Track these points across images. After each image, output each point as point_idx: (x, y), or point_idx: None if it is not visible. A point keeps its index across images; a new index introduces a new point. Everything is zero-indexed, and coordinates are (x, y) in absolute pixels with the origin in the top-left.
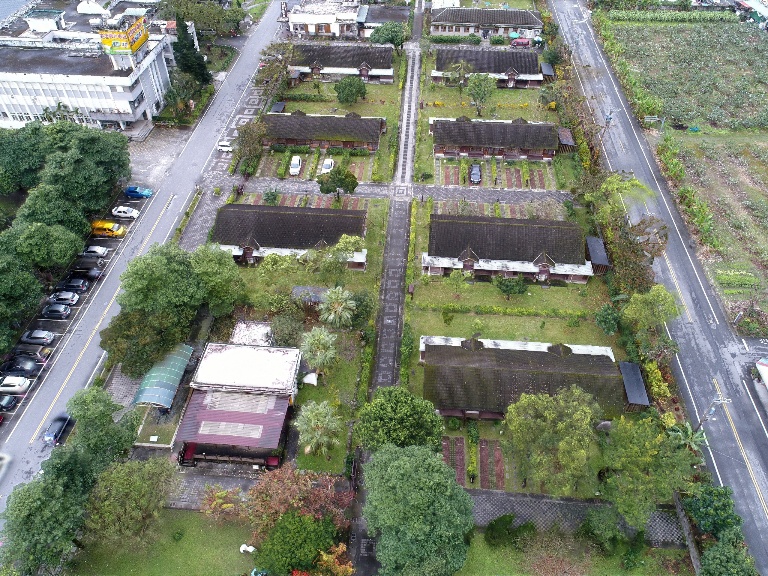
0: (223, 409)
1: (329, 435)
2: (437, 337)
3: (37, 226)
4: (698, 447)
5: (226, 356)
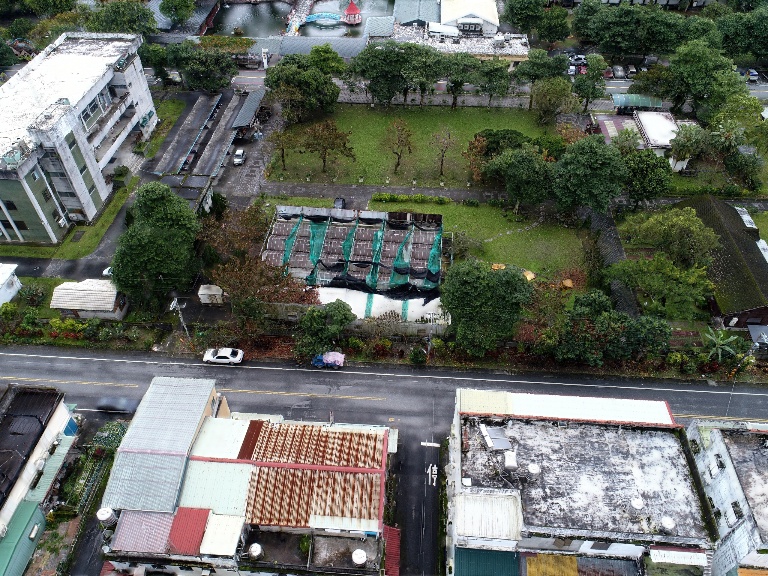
0: (624, 126)
1: (621, 148)
2: (750, 217)
3: (710, 21)
4: (715, 350)
5: (664, 120)
